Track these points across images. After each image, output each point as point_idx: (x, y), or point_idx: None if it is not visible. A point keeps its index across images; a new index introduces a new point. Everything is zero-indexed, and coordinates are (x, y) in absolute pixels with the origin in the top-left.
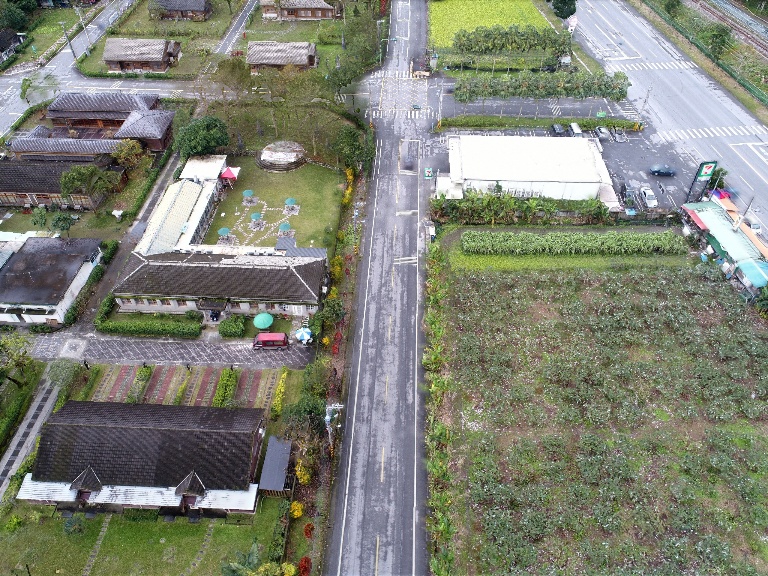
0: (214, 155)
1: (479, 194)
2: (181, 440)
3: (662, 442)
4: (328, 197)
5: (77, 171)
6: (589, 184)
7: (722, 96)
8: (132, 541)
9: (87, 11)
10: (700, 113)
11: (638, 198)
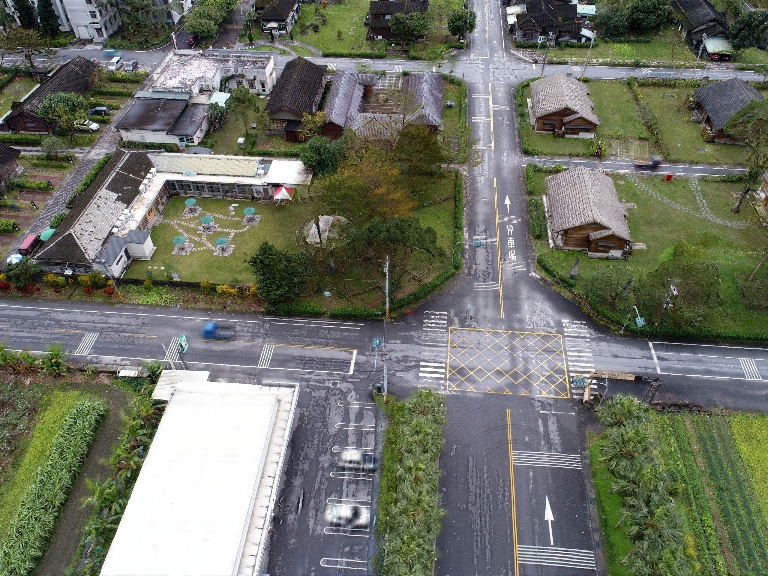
0: (311, 176)
1: None
2: None
3: None
4: None
5: None
6: None
7: None
8: None
9: (688, 60)
10: None
11: None
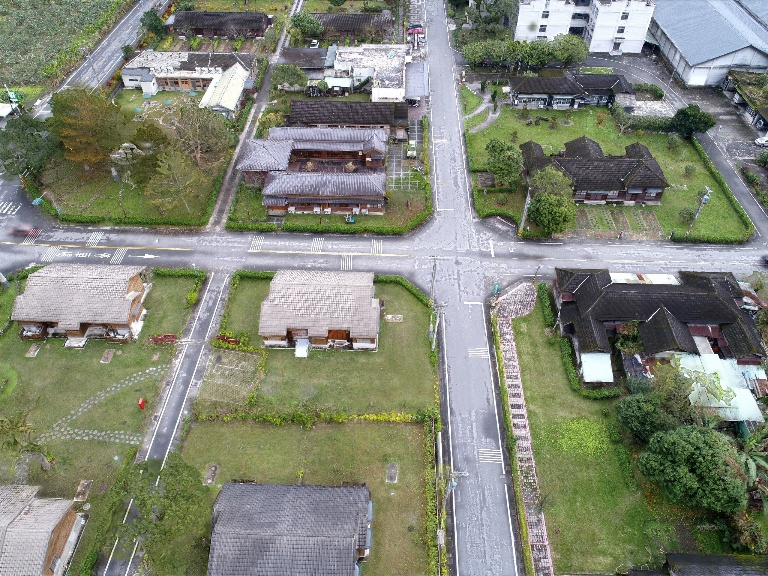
0: None
1: None
2: None
3: None
4: None
5: None
6: None
7: None
8: None
9: (558, 550)
10: None
11: None
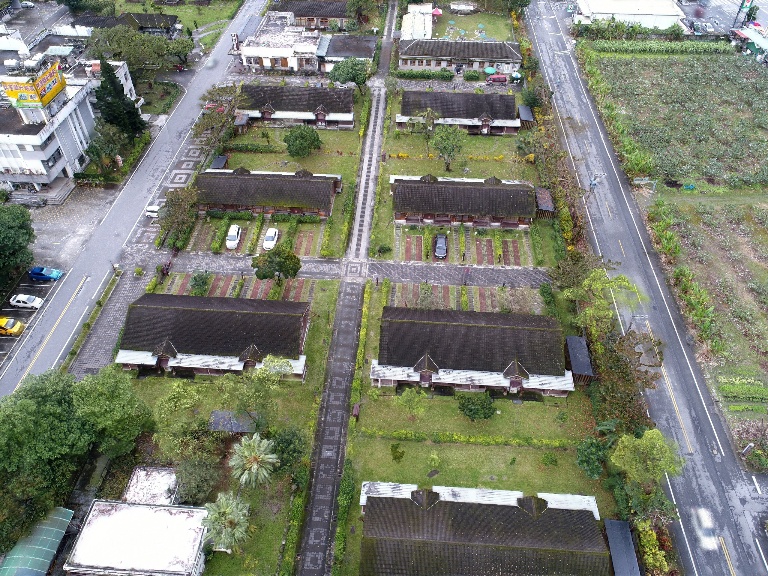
0: (424, 3)
1: (603, 20)
2: (477, 98)
3: (728, 114)
4: (502, 27)
5: None
6: (671, 17)
7: None
8: None
9: None
10: None
11: (701, 29)
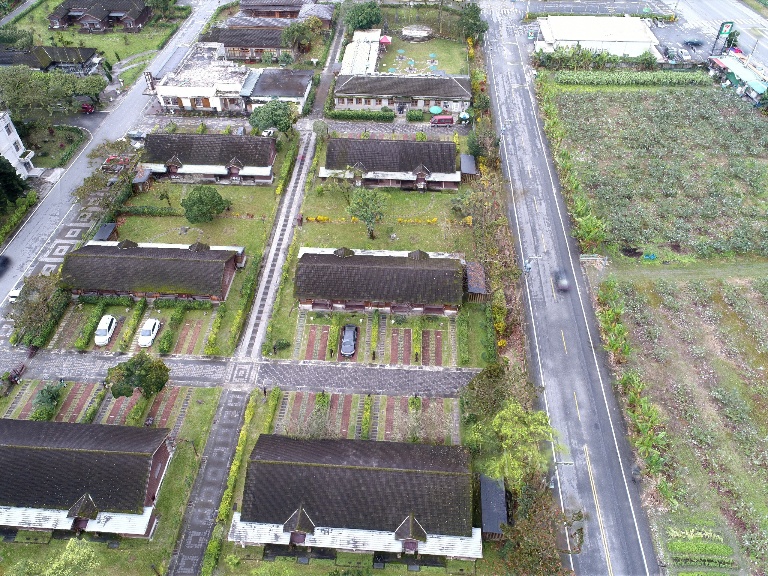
0: (372, 29)
1: (566, 48)
2: (412, 148)
3: (700, 162)
4: (456, 55)
5: (296, 25)
6: (643, 43)
7: (736, 2)
8: (389, 199)
9: None
10: (719, 11)
11: (676, 56)
